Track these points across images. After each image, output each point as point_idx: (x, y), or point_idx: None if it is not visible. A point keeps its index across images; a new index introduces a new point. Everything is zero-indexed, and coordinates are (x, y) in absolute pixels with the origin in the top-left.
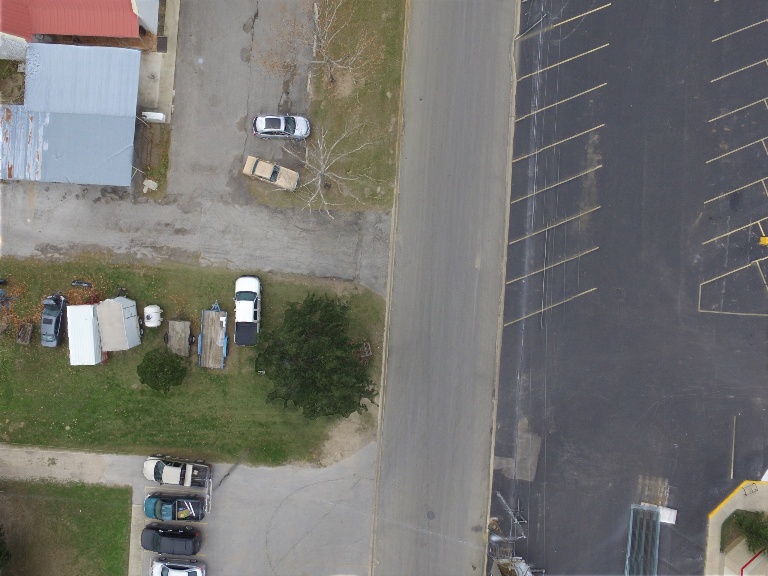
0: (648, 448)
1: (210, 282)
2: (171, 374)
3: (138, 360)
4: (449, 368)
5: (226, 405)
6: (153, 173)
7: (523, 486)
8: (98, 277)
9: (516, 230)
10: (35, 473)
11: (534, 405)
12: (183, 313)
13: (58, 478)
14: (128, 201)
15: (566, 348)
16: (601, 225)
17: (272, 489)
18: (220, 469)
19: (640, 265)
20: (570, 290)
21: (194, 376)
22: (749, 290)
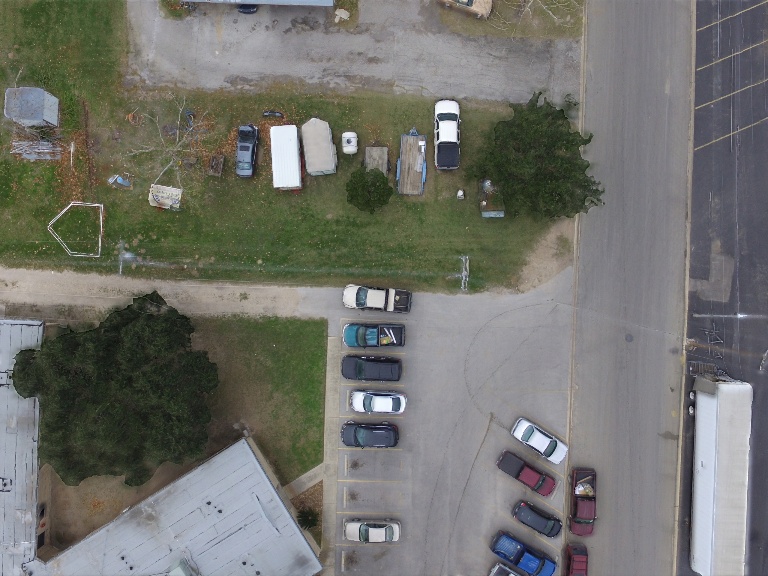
0: None
1: (405, 110)
2: (383, 189)
3: (332, 190)
4: (643, 192)
5: (422, 233)
6: (344, 3)
7: (717, 307)
8: (290, 108)
9: (703, 56)
10: (226, 309)
11: (726, 226)
12: (378, 141)
13: (250, 313)
14: (319, 31)
15: (756, 170)
16: None
17: (470, 317)
18: (417, 298)
19: None
20: (758, 113)
21: (390, 204)
22: None
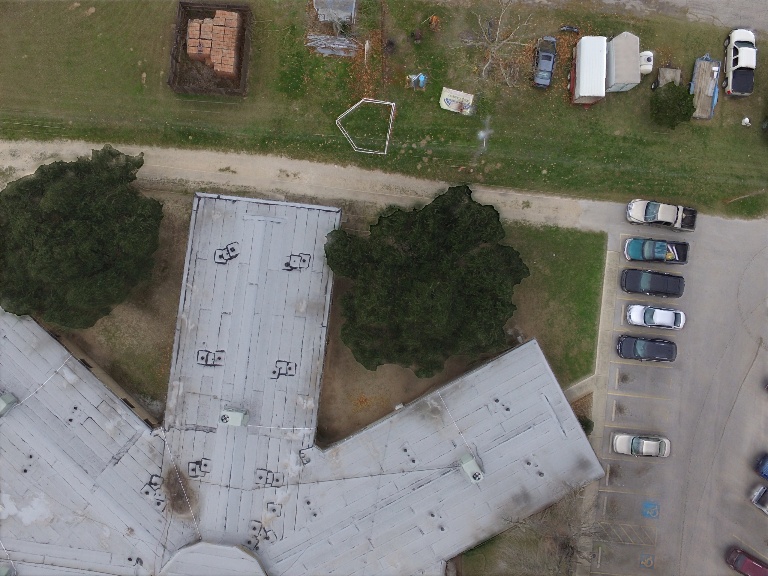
0: None
1: (697, 37)
2: None
3: (622, 108)
4: None
5: (705, 157)
6: None
7: None
8: (585, 25)
9: None
10: (508, 215)
11: None
12: None
13: (532, 221)
14: None
15: None
16: None
17: (746, 242)
18: None
19: None
20: None
21: (677, 126)
22: None
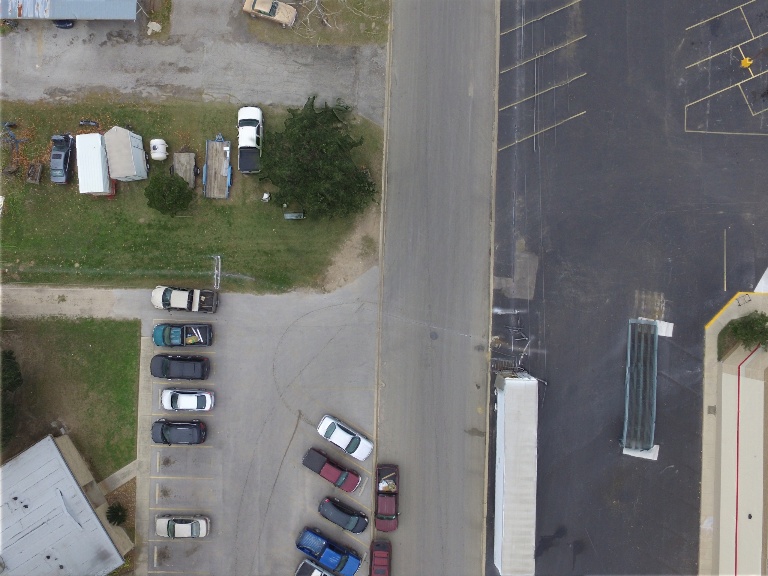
0: (643, 263)
1: (213, 117)
2: (178, 193)
3: None
4: (447, 192)
5: (231, 235)
6: (157, 16)
7: (523, 305)
8: (105, 117)
9: (506, 59)
10: (45, 311)
11: (530, 225)
12: (188, 148)
13: (68, 315)
14: (133, 43)
15: (559, 169)
16: (588, 52)
17: (278, 316)
18: (227, 299)
19: (627, 89)
20: (560, 114)
21: (200, 208)
22: (732, 110)
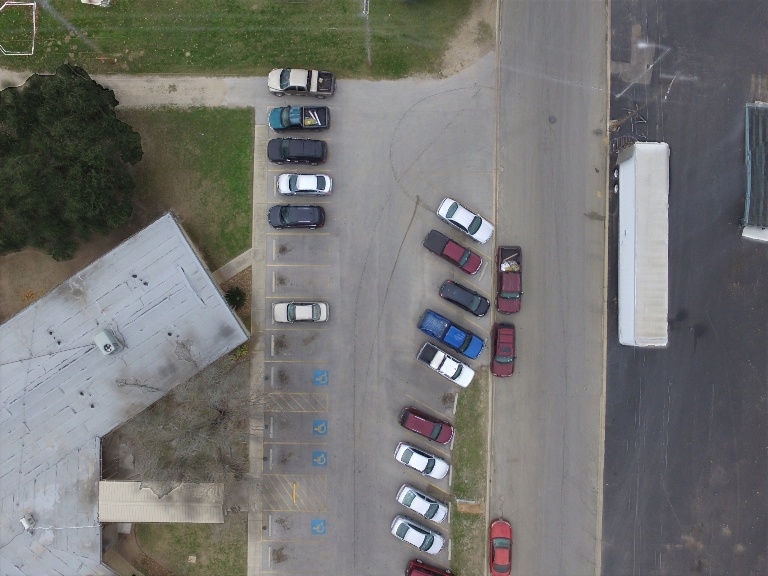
0: (758, 47)
1: None
2: None
3: None
4: None
5: (346, 21)
6: None
7: (640, 89)
8: None
9: None
10: (156, 101)
11: (646, 10)
12: None
13: (179, 104)
14: None
15: None
16: None
17: (394, 102)
18: (342, 85)
19: None
20: None
21: None
22: None
